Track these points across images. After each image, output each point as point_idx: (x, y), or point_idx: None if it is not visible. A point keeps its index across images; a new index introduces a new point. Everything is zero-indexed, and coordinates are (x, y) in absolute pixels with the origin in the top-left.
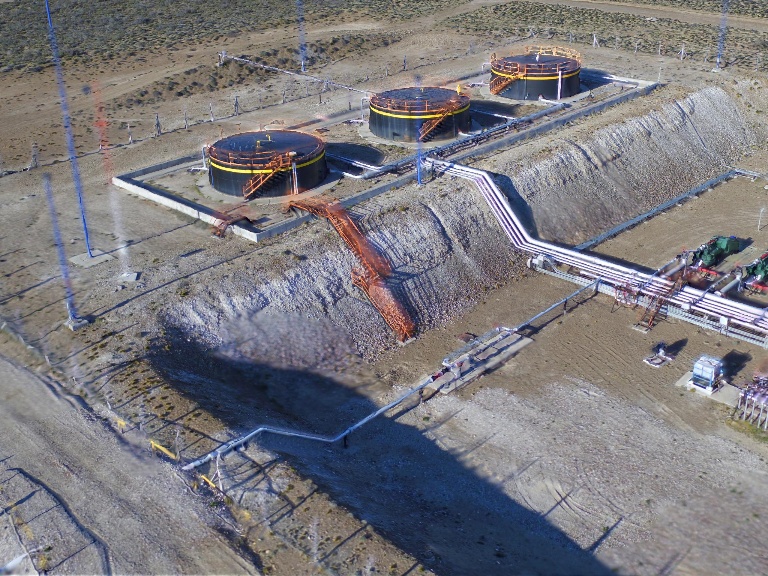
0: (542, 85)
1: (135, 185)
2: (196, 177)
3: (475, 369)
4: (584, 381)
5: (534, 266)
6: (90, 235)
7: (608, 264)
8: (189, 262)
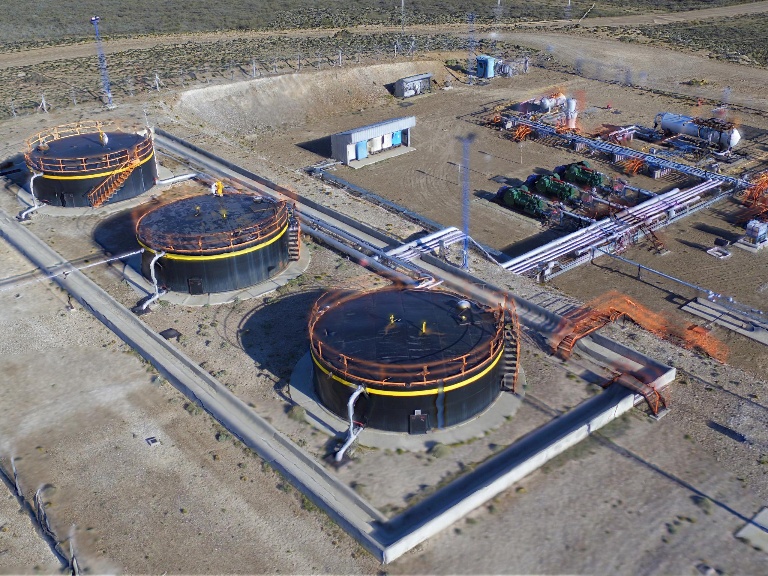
0: (149, 166)
1: (448, 511)
2: (373, 455)
3: (767, 328)
4: (765, 285)
5: (545, 278)
6: (675, 555)
7: (567, 238)
8: (762, 430)
